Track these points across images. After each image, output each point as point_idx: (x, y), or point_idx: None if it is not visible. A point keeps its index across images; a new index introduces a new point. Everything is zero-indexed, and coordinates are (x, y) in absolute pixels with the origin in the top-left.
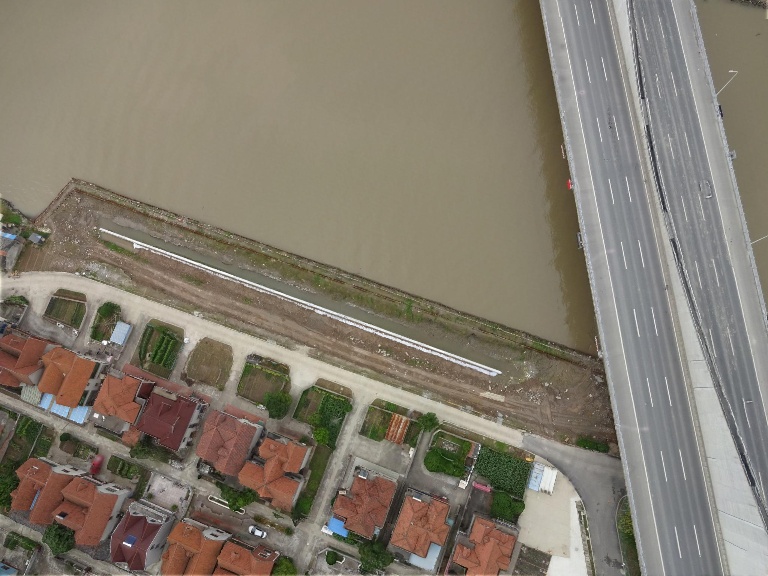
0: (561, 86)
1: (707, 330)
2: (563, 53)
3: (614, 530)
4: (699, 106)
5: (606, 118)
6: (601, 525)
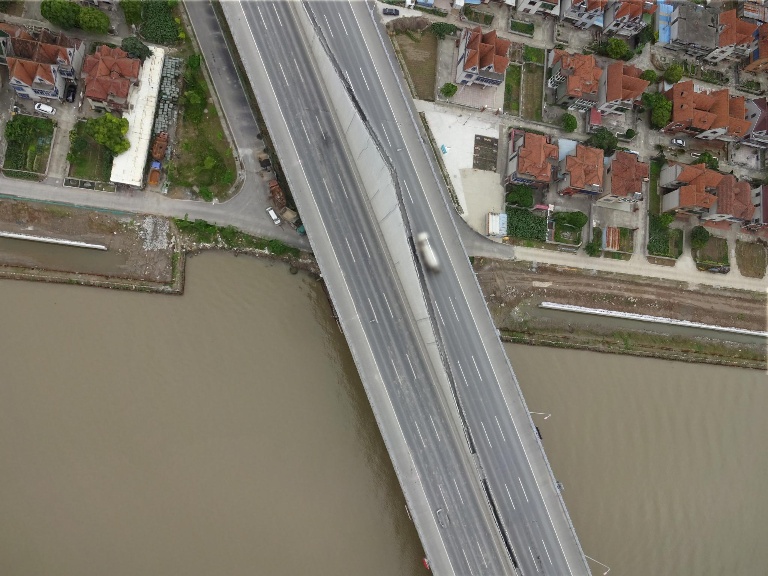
0: None
1: (418, 377)
2: None
3: None
4: None
5: (545, 567)
6: None
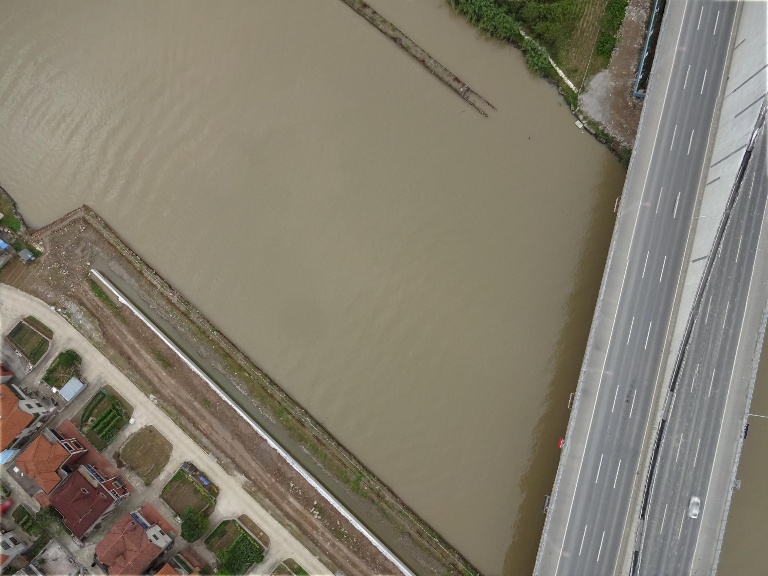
0: (597, 335)
1: None
2: (614, 300)
3: None
4: (726, 417)
5: (627, 389)
6: None
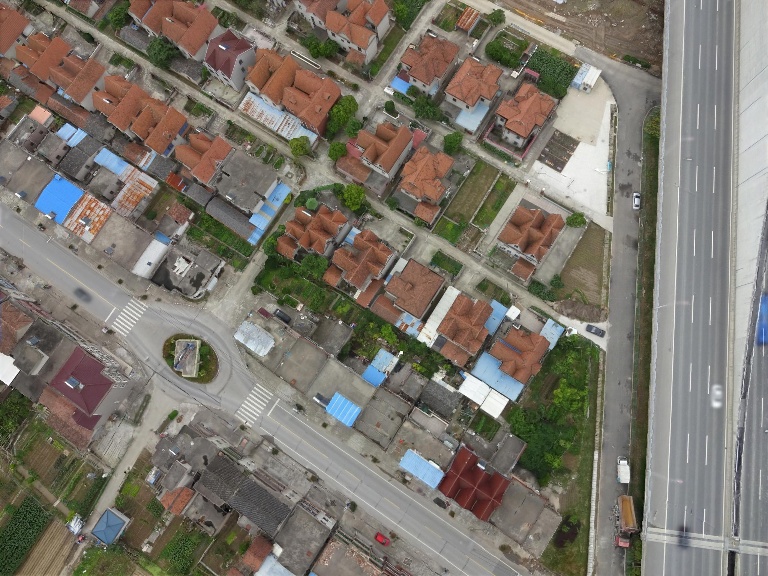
0: None
1: None
2: None
3: (640, 131)
4: None
5: None
6: (629, 125)
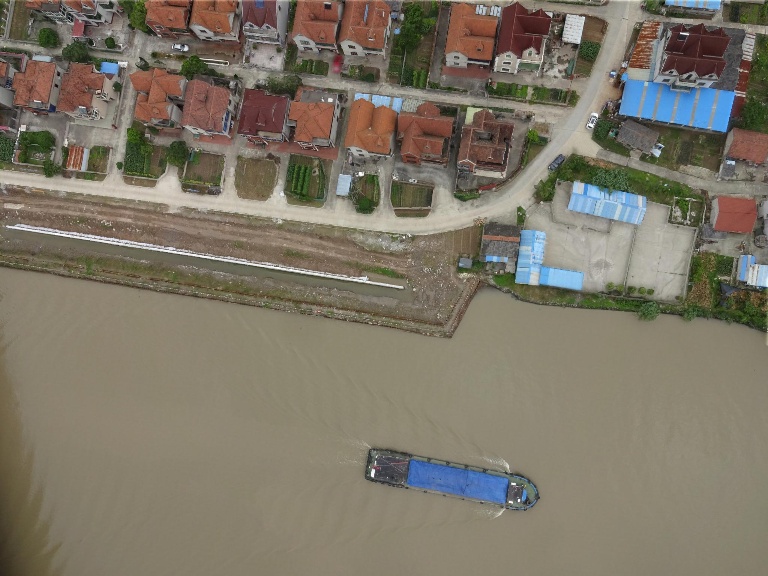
0: None
1: None
2: None
3: None
4: None
5: None
6: None
